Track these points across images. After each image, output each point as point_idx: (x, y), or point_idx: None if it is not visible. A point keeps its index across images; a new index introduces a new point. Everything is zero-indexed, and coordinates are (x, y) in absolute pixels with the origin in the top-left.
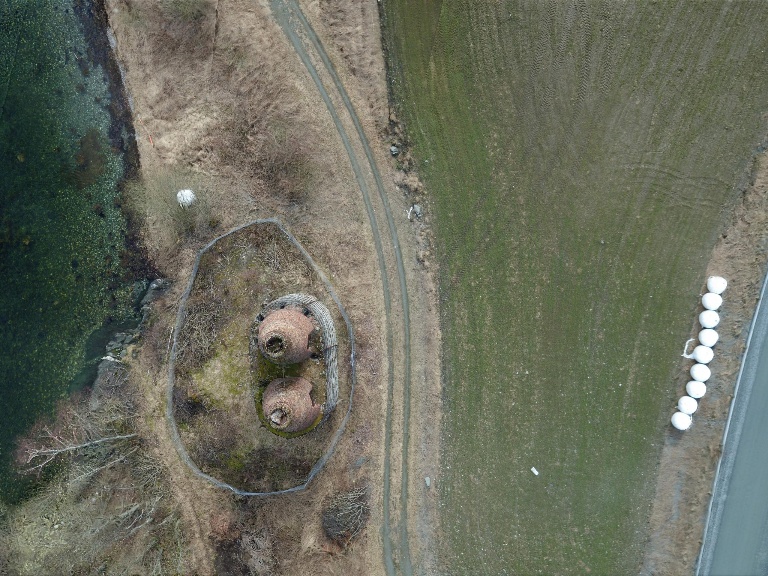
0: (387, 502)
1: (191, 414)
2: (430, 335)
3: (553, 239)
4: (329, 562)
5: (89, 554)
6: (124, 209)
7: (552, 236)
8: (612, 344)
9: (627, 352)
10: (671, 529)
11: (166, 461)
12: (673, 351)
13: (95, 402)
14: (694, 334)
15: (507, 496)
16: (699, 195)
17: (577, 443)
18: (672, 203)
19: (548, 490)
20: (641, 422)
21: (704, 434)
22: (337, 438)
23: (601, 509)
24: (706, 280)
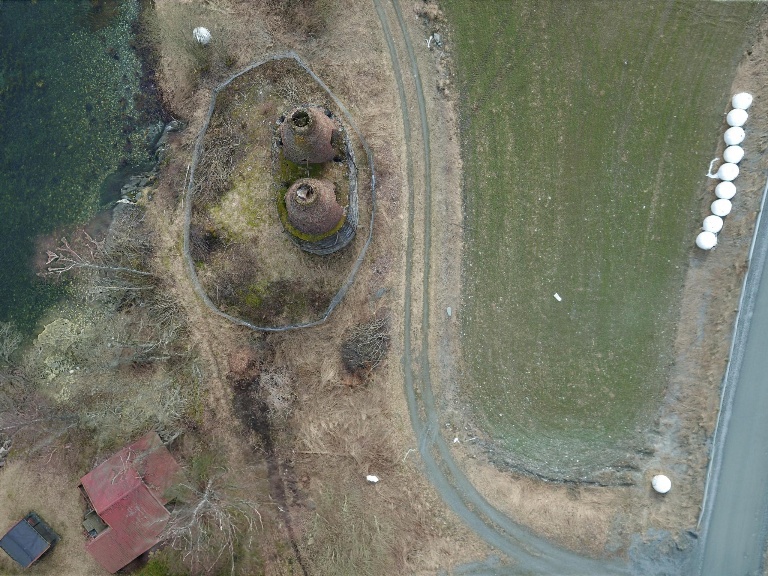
0: (408, 332)
1: (208, 251)
2: (451, 164)
3: (575, 62)
4: (349, 396)
5: (105, 397)
6: (139, 50)
7: (574, 59)
8: (636, 166)
9: (651, 174)
10: (696, 352)
11: (183, 301)
12: (698, 171)
13: None
14: (719, 153)
15: (530, 324)
16: (723, 12)
17: (600, 267)
18: (696, 21)
19: (571, 316)
20: (665, 244)
21: (729, 253)
22: (357, 267)
23: (625, 334)
24: (731, 98)
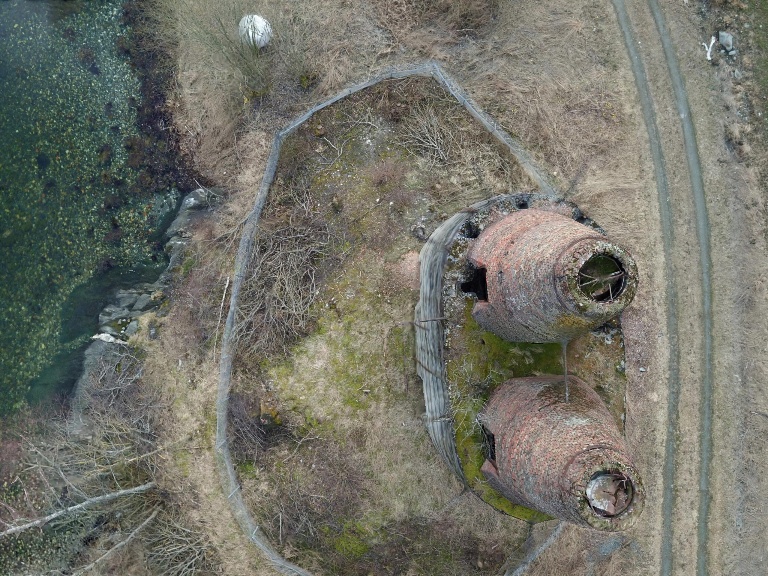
0: None
1: (263, 446)
2: (753, 293)
3: None
4: None
5: None
6: (136, 57)
7: None
8: None
9: None
10: None
11: (212, 535)
12: None
13: (77, 419)
14: None
15: None
16: None
17: None
18: None
19: None
20: None
21: None
22: None
23: None
24: None
